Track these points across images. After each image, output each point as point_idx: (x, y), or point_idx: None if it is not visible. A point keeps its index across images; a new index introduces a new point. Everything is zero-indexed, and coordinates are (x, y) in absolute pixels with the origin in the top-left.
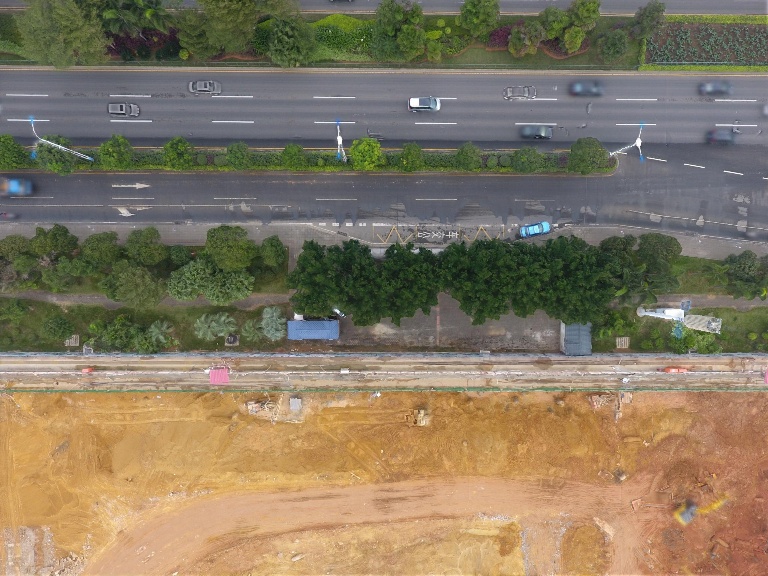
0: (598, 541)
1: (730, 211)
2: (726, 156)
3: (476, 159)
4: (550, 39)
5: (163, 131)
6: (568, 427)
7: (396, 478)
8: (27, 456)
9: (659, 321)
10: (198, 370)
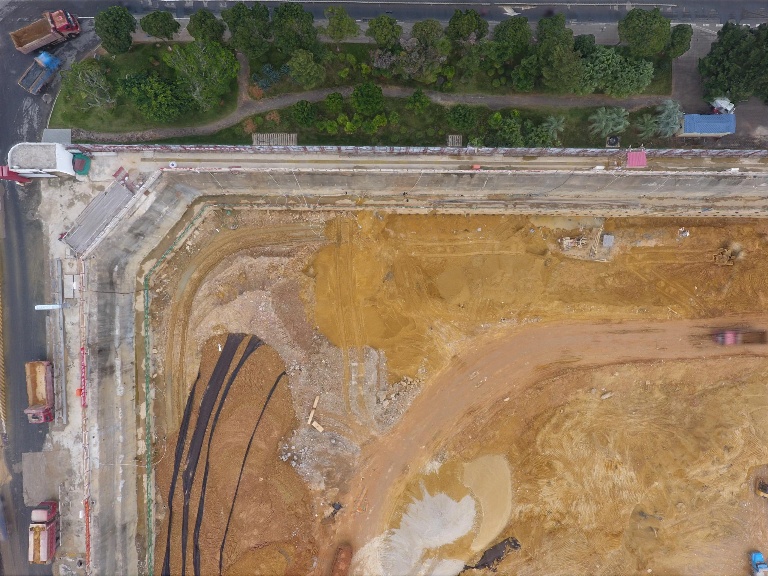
0: None
1: None
2: None
3: None
4: None
5: None
6: None
7: (711, 314)
8: (364, 279)
9: None
10: (581, 170)
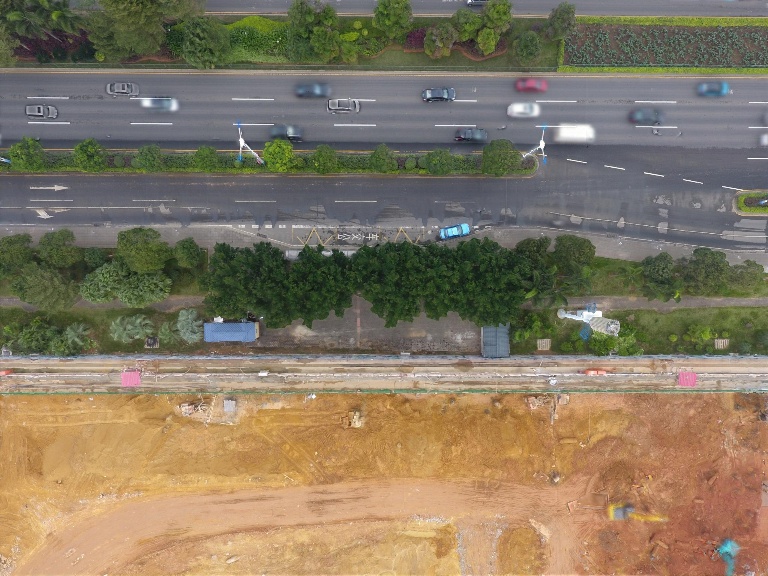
0: (535, 543)
1: (651, 213)
2: (646, 158)
3: (389, 161)
4: (465, 41)
5: (81, 133)
6: (503, 429)
7: (330, 480)
8: None
9: (580, 323)
10: (117, 372)
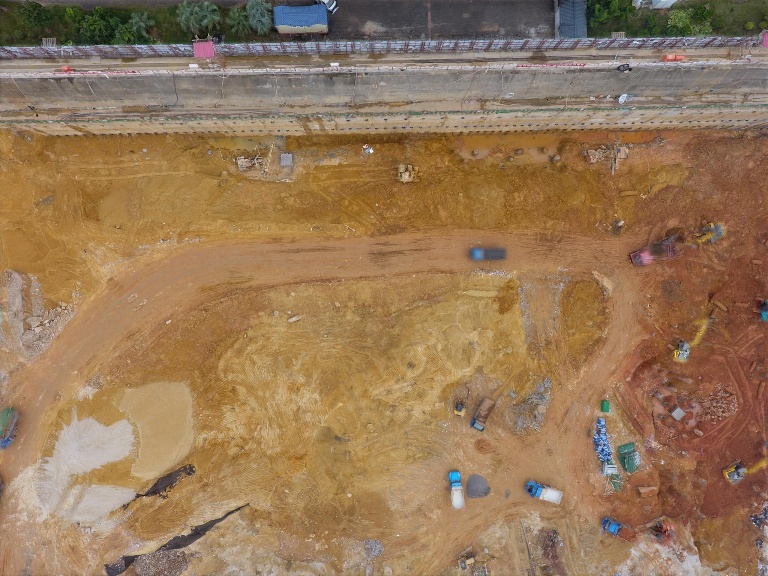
0: (597, 297)
1: None
2: None
3: None
4: None
5: None
6: (564, 179)
7: (392, 231)
8: (10, 202)
9: (655, 13)
10: None
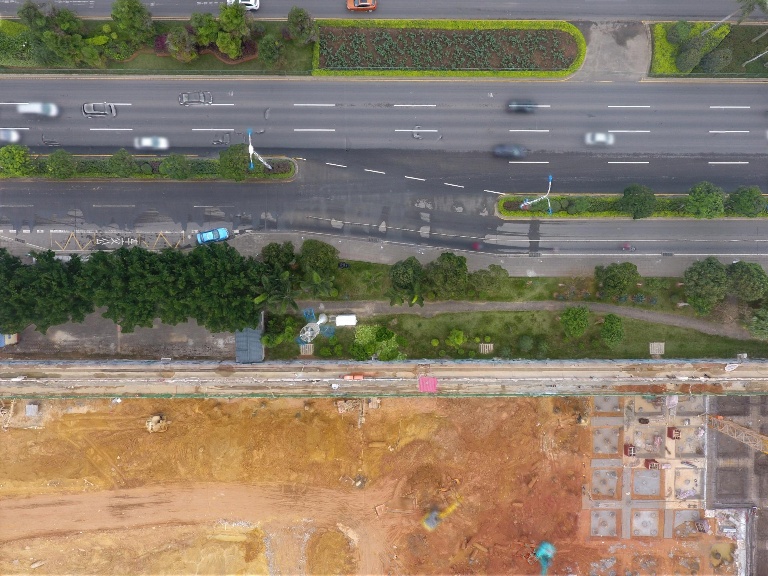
0: (344, 547)
1: (412, 217)
2: (407, 162)
3: (125, 166)
4: (210, 44)
5: None
6: (309, 433)
7: (131, 484)
8: None
9: (342, 328)
10: None
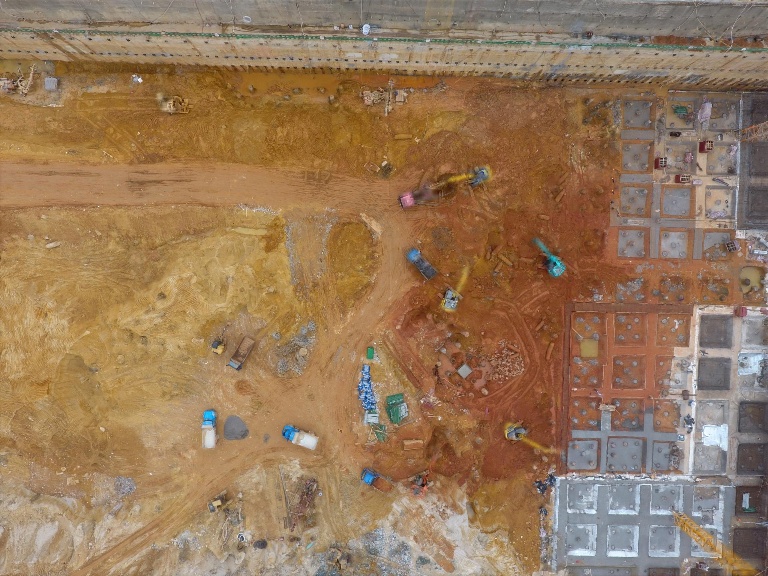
0: (367, 241)
1: None
2: None
3: None
4: None
5: None
6: (334, 118)
7: (151, 160)
8: None
9: None
10: None
